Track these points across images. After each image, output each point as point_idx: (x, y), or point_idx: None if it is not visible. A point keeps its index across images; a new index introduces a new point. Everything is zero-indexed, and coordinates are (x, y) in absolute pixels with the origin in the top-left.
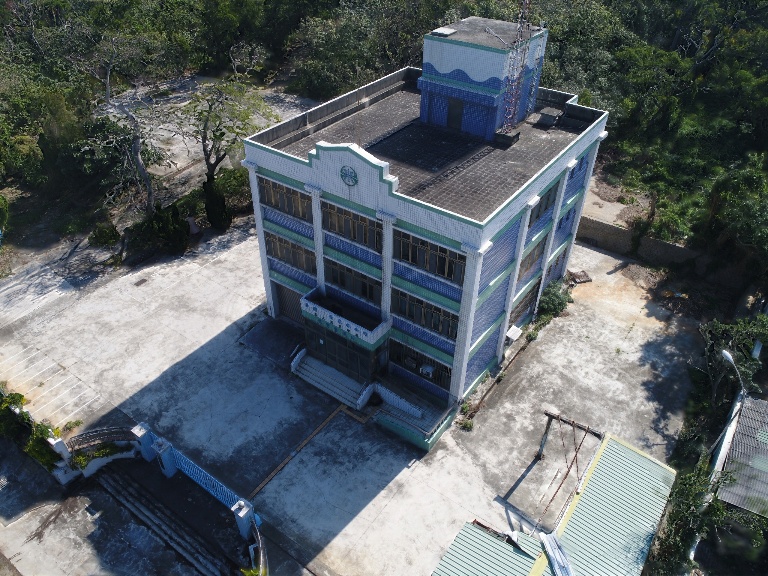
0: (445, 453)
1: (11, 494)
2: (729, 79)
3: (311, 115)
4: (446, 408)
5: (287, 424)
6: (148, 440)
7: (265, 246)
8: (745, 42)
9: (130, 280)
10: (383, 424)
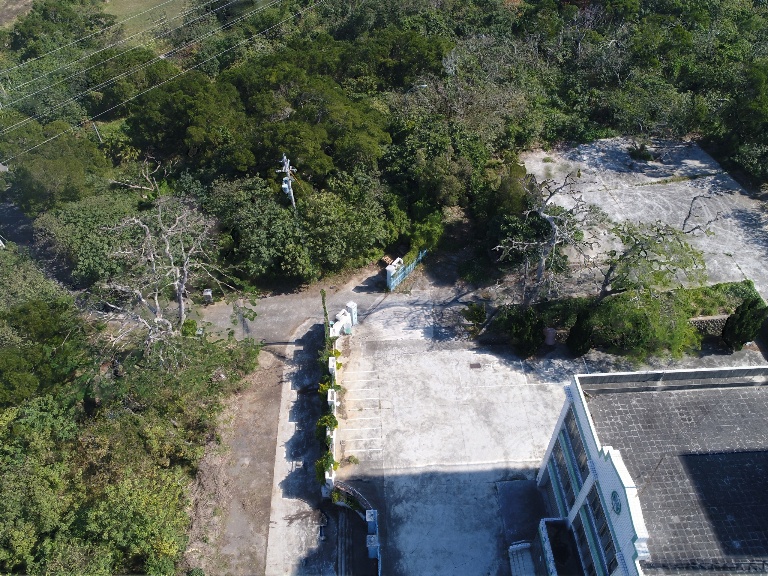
0: None
1: (299, 477)
2: None
3: (670, 375)
4: None
5: None
6: (373, 524)
7: (554, 445)
8: None
9: (470, 358)
10: None
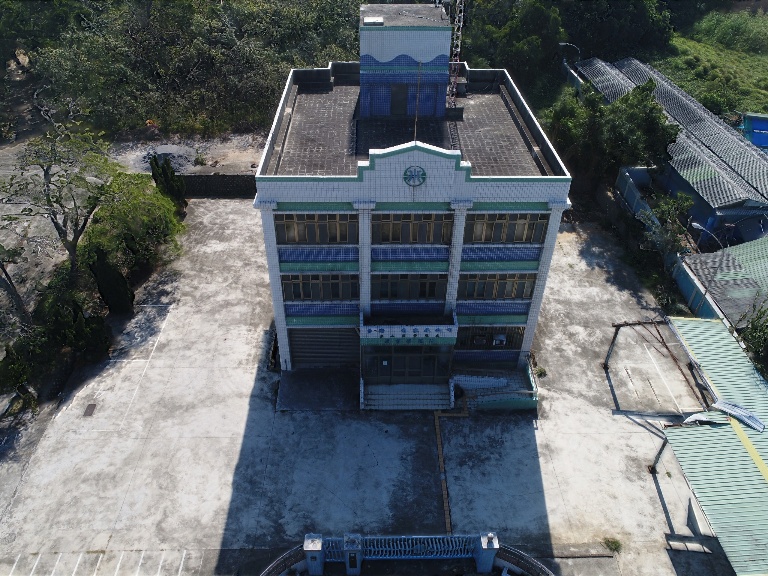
0: (549, 402)
1: None
2: (481, 34)
3: None
4: (516, 367)
5: (409, 456)
6: (321, 550)
7: (282, 293)
8: (487, 1)
9: (72, 414)
10: (484, 407)
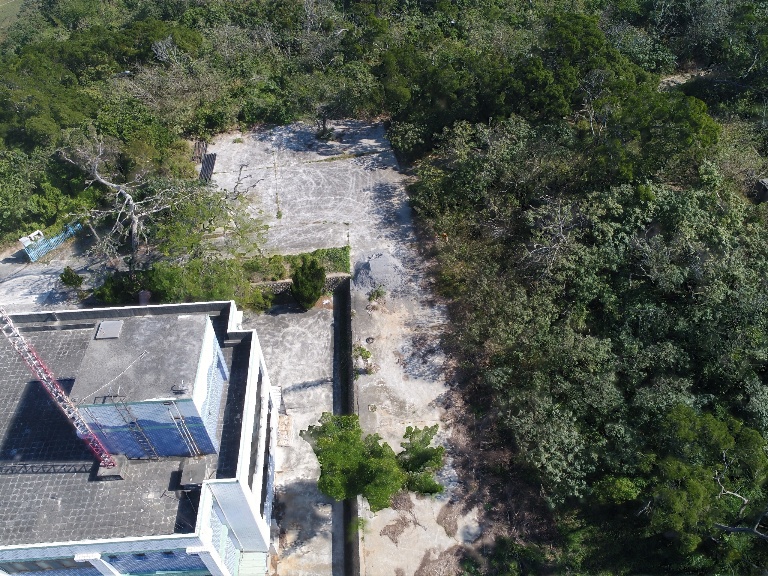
0: None
1: None
2: None
3: (62, 315)
4: None
5: None
6: None
7: None
8: None
9: None
10: None
